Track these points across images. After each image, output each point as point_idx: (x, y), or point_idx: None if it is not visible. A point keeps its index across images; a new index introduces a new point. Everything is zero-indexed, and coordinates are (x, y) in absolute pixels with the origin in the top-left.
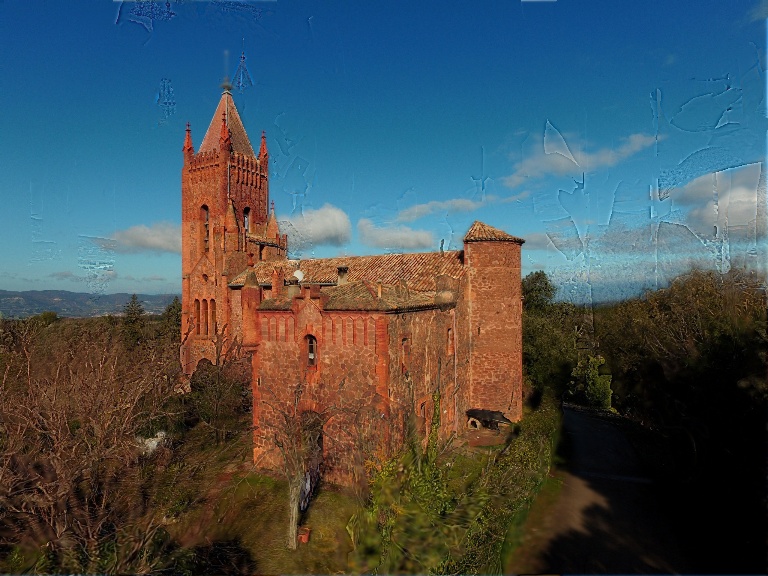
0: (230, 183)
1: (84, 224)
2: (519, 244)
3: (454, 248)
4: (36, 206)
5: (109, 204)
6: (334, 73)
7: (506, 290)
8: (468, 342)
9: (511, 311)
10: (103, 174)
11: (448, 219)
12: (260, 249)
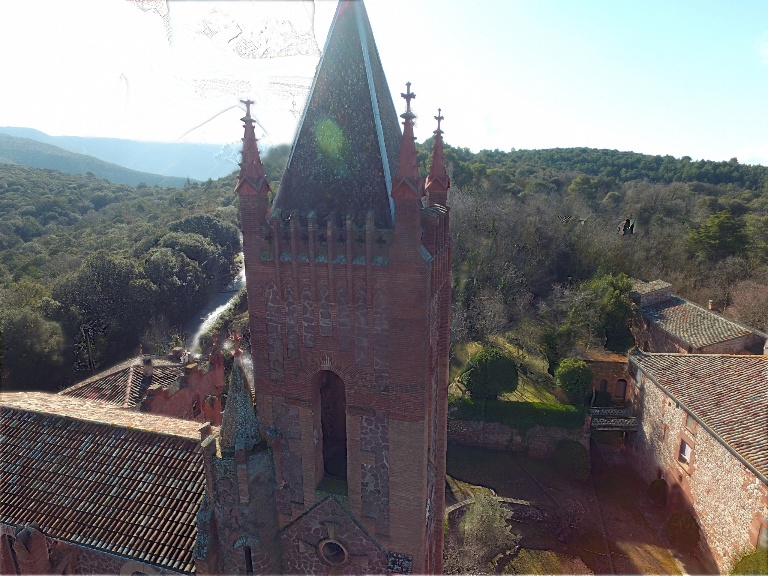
0: None
1: None
2: None
3: None
4: None
5: None
6: None
7: None
8: None
9: None
10: None
11: None
12: None
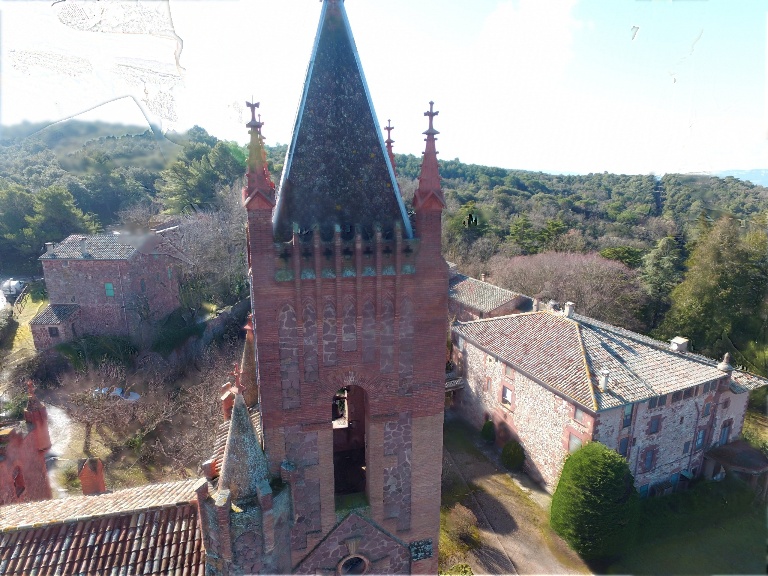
0: None
1: None
2: None
3: None
4: None
5: None
6: None
7: None
8: None
9: None
10: None
11: None
12: None
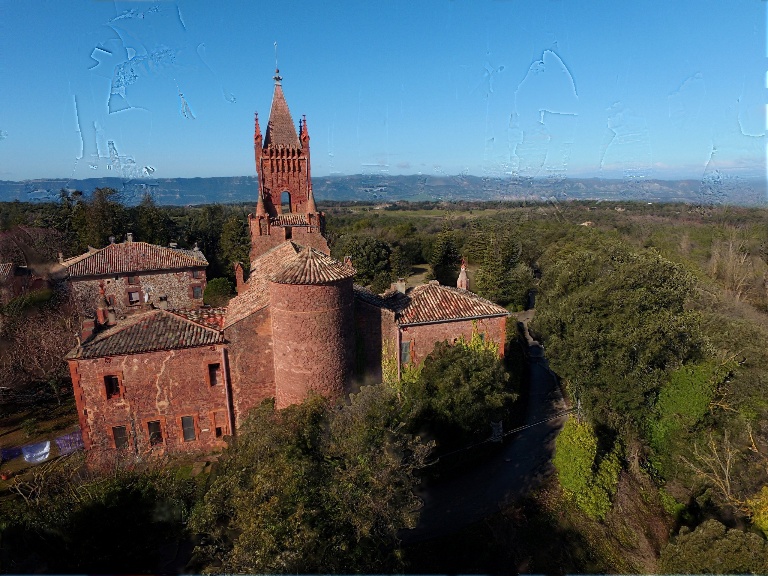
0: (264, 174)
1: (366, 154)
2: (313, 285)
3: (714, 173)
4: (330, 145)
5: (385, 134)
6: (231, 91)
7: (291, 334)
8: (272, 373)
9: (298, 356)
10: (379, 108)
11: (712, 128)
12: (289, 230)
